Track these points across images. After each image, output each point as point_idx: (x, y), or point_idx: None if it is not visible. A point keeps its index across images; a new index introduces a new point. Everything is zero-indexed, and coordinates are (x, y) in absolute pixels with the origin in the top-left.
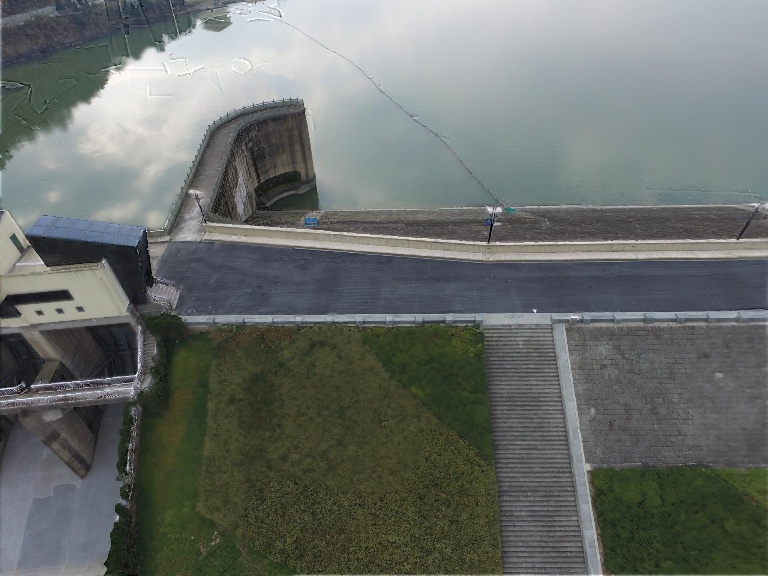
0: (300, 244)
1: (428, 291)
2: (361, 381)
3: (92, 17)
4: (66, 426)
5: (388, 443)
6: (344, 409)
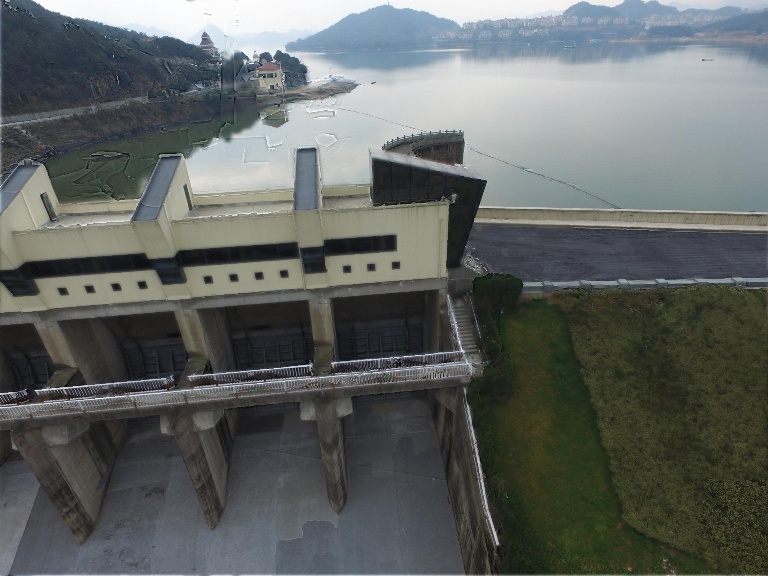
0: (579, 224)
1: None
2: None
3: (178, 105)
4: None
5: None
6: None
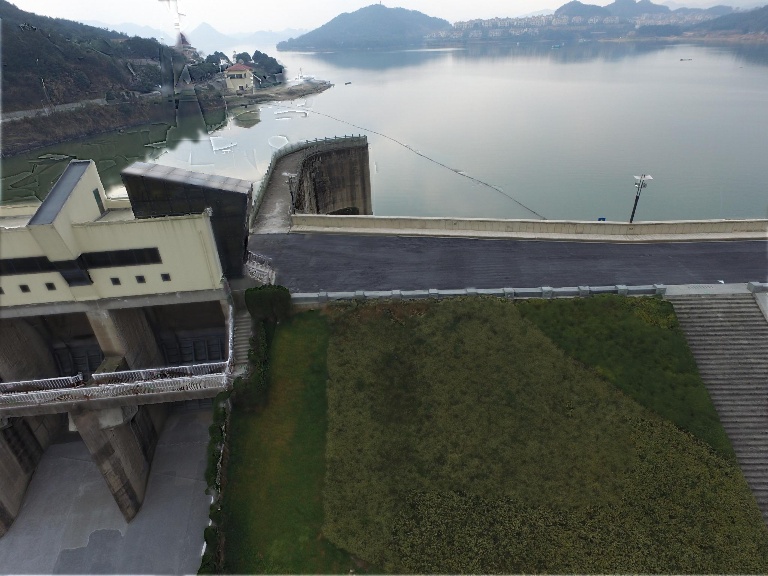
0: (405, 232)
1: (577, 267)
2: (528, 360)
3: (138, 107)
4: (121, 442)
5: (582, 437)
6: (512, 394)
